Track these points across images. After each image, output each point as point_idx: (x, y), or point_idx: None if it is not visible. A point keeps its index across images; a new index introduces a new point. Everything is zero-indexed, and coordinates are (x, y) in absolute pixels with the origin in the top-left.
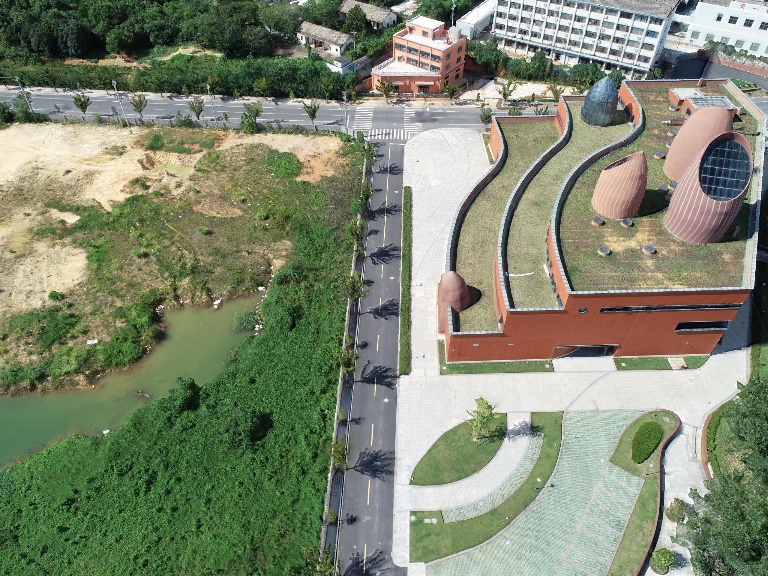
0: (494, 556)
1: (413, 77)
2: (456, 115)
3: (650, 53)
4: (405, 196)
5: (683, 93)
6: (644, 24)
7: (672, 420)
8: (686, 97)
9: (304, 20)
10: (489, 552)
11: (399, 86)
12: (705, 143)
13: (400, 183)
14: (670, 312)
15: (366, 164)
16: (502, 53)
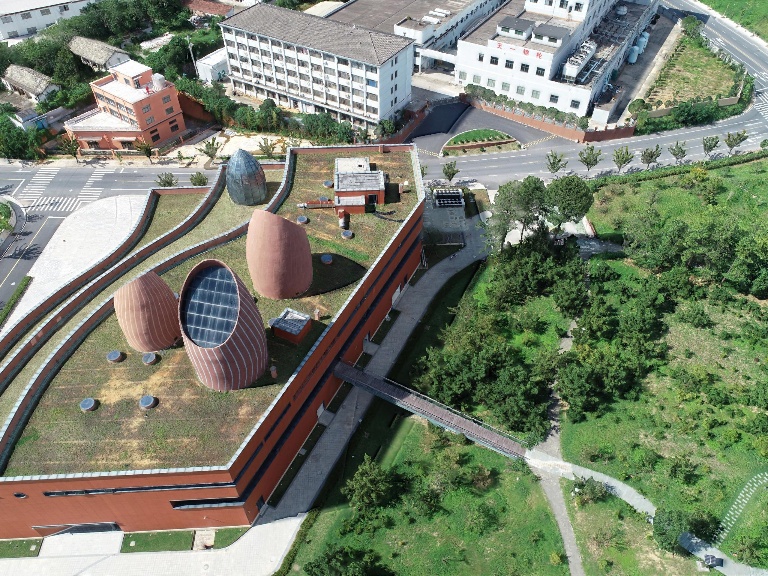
0: None
1: (110, 132)
2: (150, 178)
3: (376, 104)
4: (16, 291)
5: (346, 165)
6: (361, 72)
7: None
8: None
9: (12, 63)
10: None
11: (98, 142)
12: (260, 253)
13: (25, 271)
14: (144, 492)
15: (0, 246)
16: (228, 101)
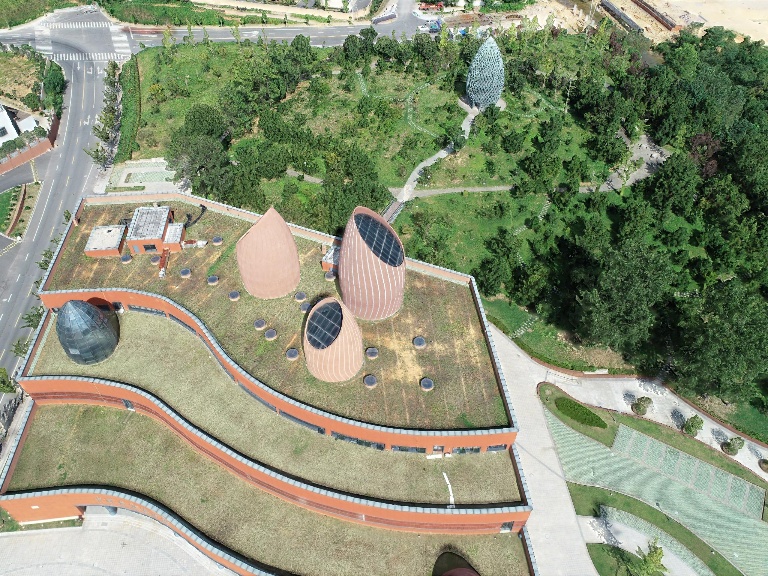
0: (757, 570)
1: None
2: None
3: None
4: None
5: (101, 242)
6: None
7: (548, 388)
8: (128, 240)
9: None
10: (755, 575)
11: None
12: (288, 244)
13: None
14: None
15: None
16: None
